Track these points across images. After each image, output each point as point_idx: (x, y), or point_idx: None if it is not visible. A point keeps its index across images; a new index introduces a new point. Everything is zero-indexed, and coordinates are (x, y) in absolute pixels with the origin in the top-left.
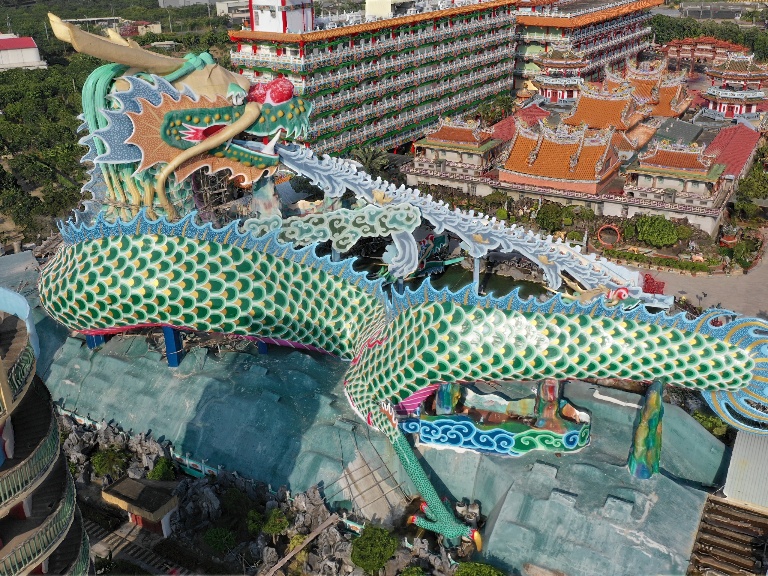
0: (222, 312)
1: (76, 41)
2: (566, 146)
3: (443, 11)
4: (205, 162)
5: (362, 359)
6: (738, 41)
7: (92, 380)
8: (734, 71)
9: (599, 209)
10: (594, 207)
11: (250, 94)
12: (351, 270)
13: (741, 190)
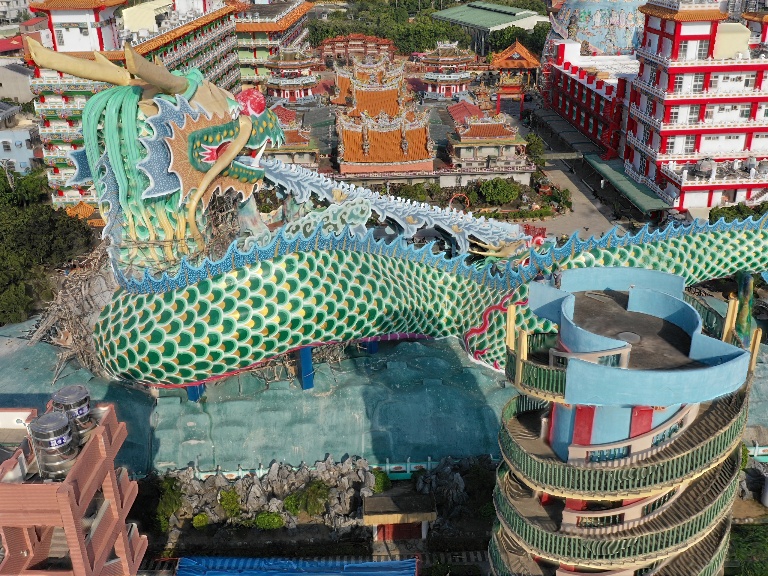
0: (365, 316)
1: (134, 62)
2: (389, 133)
3: (197, 21)
4: (217, 183)
5: (498, 325)
6: None
7: (223, 430)
8: (447, 57)
9: (436, 183)
10: (432, 182)
11: None
12: (431, 254)
13: (533, 149)
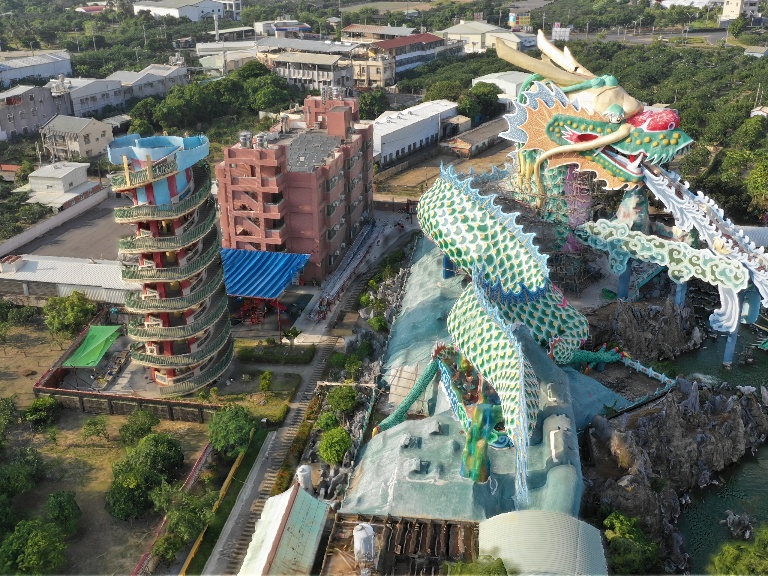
0: (455, 250)
1: (498, 50)
2: None
3: None
4: (577, 160)
5: None
6: None
7: None
8: None
9: None
10: None
11: (634, 117)
12: (545, 264)
13: None
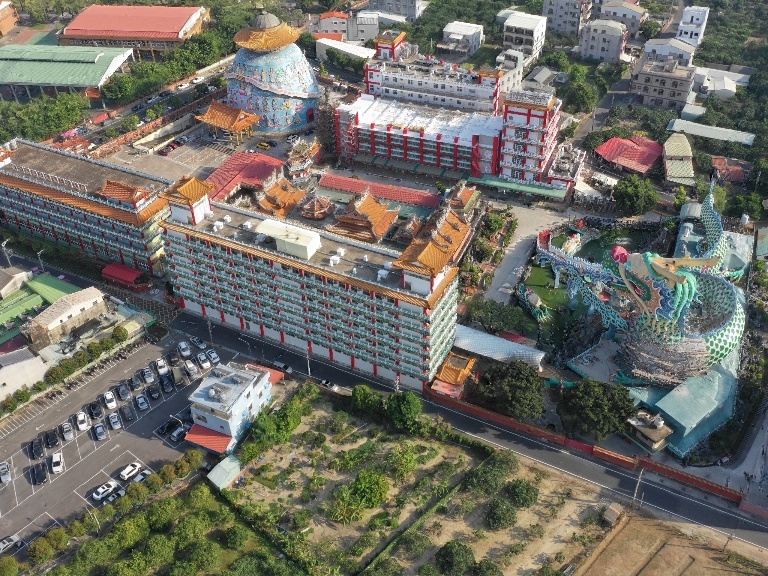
0: None
1: None
2: None
3: None
4: None
5: None
6: (7, 136)
7: None
8: None
9: None
10: None
11: None
12: None
13: None
